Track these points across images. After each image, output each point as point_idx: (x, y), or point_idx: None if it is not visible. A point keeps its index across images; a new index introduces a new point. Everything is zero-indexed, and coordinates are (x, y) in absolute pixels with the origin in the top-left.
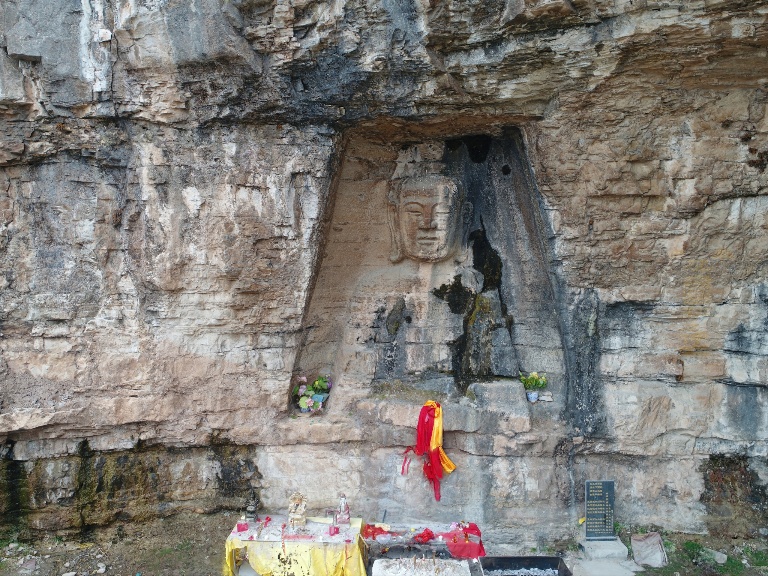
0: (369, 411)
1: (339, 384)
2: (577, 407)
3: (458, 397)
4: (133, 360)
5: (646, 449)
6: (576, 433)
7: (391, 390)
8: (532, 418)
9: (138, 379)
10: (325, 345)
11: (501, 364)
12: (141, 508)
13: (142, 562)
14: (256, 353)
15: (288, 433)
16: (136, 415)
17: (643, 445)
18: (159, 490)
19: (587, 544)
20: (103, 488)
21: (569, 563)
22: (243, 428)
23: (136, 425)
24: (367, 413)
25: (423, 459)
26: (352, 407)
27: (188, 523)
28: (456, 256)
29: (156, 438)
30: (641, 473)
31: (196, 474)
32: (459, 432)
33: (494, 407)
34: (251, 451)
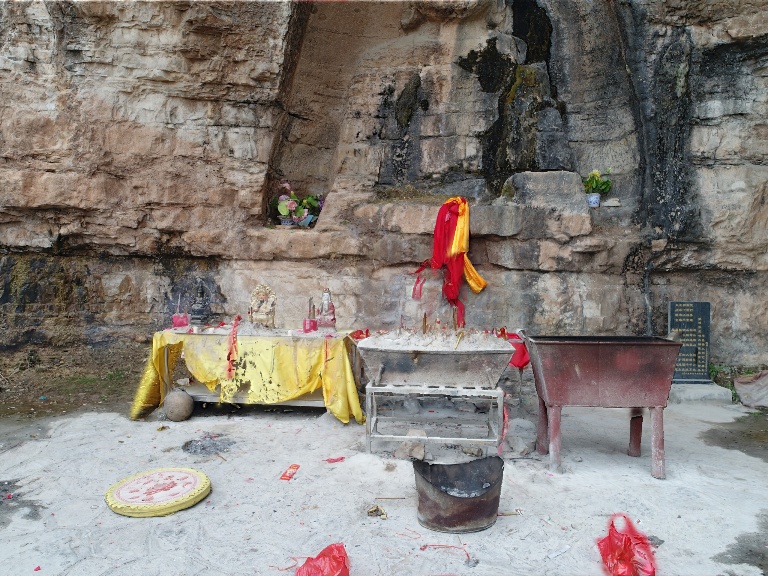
0: (370, 218)
1: (332, 190)
2: (658, 200)
3: (490, 200)
4: (49, 121)
5: (755, 260)
6: (656, 234)
7: (400, 196)
8: (592, 223)
9: (56, 148)
10: (316, 152)
11: (550, 153)
12: (61, 329)
13: (52, 386)
14: (219, 131)
15: (261, 244)
16: (52, 195)
17: (752, 253)
18: (87, 309)
19: (672, 385)
20: (10, 298)
21: (671, 335)
22: (201, 231)
23: (54, 212)
24: (367, 220)
25: (442, 279)
26: (348, 214)
27: (124, 353)
28: (490, 14)
29: (83, 236)
30: (747, 295)
31: (138, 292)
32: (491, 240)
33: (541, 201)
34: (212, 267)
